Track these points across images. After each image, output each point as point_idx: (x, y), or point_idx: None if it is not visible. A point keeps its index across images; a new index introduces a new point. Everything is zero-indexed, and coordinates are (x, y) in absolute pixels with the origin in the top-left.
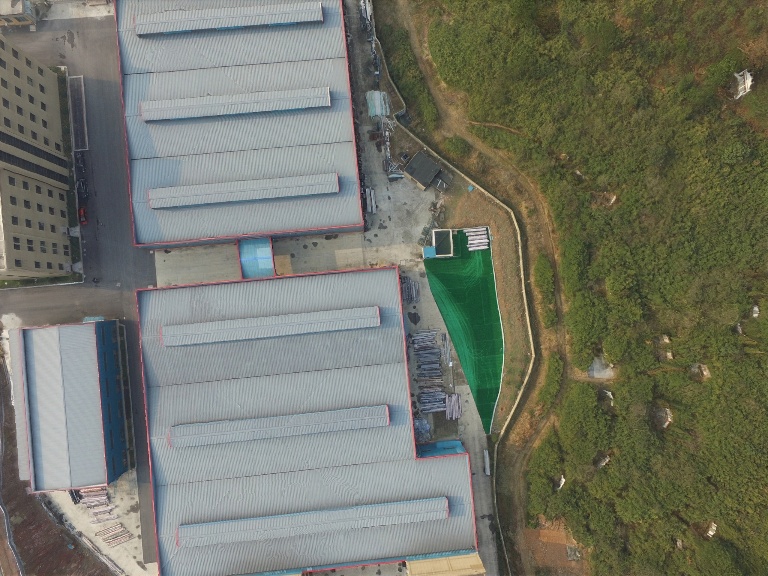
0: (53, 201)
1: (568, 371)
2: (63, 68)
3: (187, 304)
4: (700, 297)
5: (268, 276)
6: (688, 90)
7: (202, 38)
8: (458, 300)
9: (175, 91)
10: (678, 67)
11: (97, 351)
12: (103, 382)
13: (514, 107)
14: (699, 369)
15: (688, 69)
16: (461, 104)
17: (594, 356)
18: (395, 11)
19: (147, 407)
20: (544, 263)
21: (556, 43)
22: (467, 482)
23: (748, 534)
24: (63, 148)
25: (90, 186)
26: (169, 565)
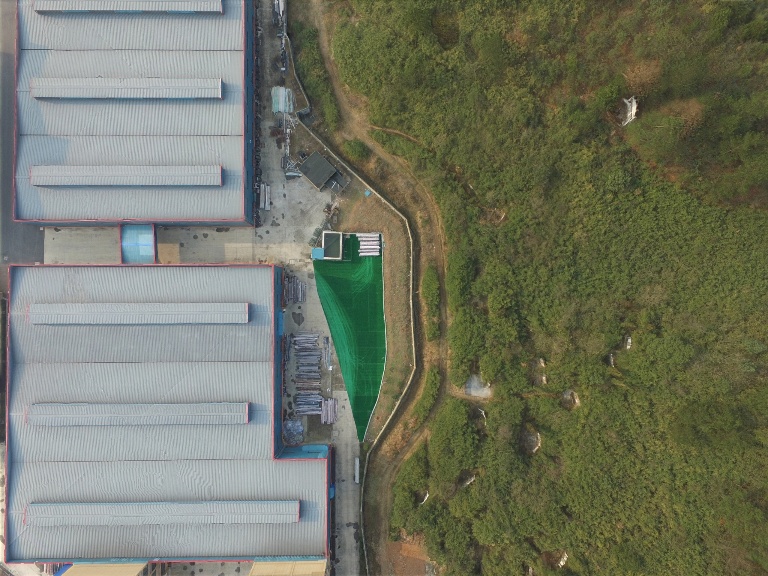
0: None
1: (447, 386)
2: None
3: (60, 284)
4: (574, 323)
5: (148, 263)
6: (574, 112)
7: (101, 19)
8: (344, 304)
9: (69, 70)
10: (569, 88)
11: None
12: None
13: (410, 115)
14: (571, 396)
15: (580, 91)
16: (364, 107)
17: (472, 373)
18: (307, 8)
19: (9, 382)
20: (431, 275)
21: (453, 53)
22: (324, 488)
23: (595, 568)
24: None
25: None
26: (17, 542)
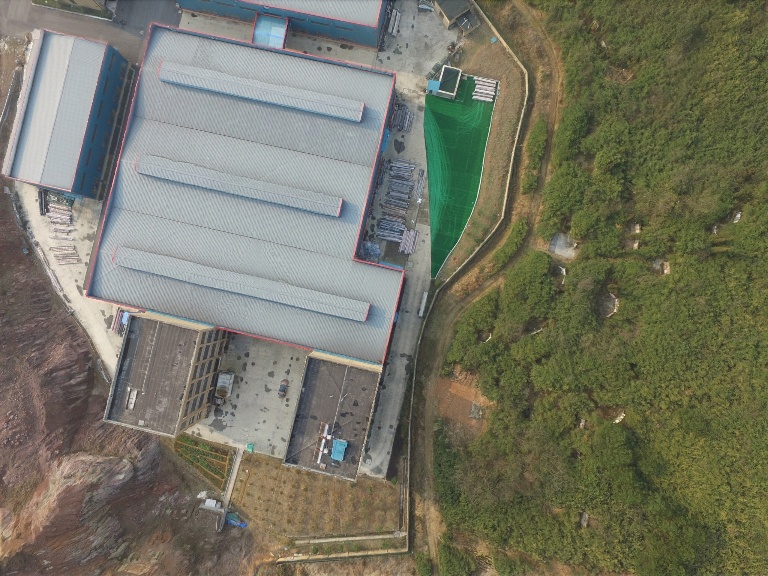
0: None
1: (531, 241)
2: None
3: (192, 51)
4: (684, 188)
5: None
6: None
7: None
8: (447, 143)
9: None
10: None
11: (101, 69)
12: (97, 101)
13: None
14: (661, 267)
15: None
16: None
17: (561, 231)
18: None
19: (127, 131)
20: (541, 127)
21: None
22: (395, 298)
23: (653, 427)
24: None
25: None
26: (100, 280)
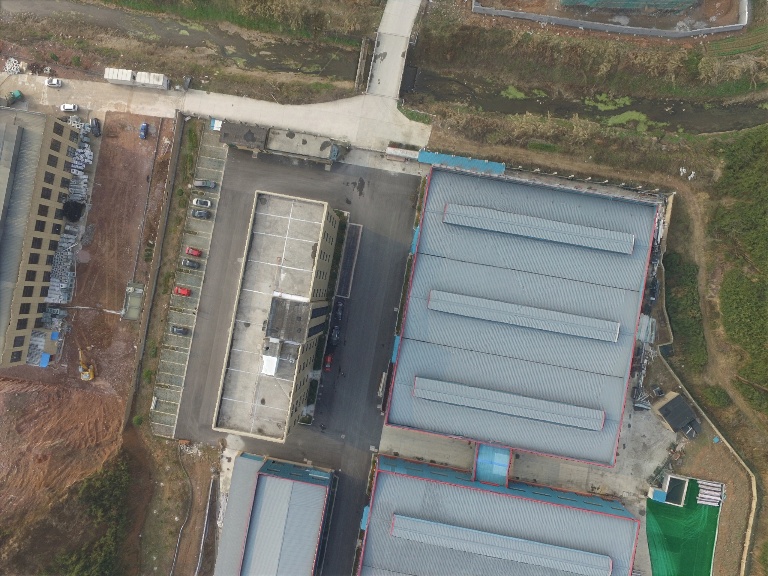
0: (312, 350)
1: None
2: (346, 214)
3: (420, 496)
4: None
5: (499, 483)
6: None
7: (503, 237)
8: (671, 548)
9: (463, 283)
10: None
11: None
12: None
13: None
14: None
15: None
16: (734, 356)
17: None
18: (689, 241)
19: None
20: None
21: None
22: None
23: None
24: (327, 291)
25: (342, 334)
26: None
